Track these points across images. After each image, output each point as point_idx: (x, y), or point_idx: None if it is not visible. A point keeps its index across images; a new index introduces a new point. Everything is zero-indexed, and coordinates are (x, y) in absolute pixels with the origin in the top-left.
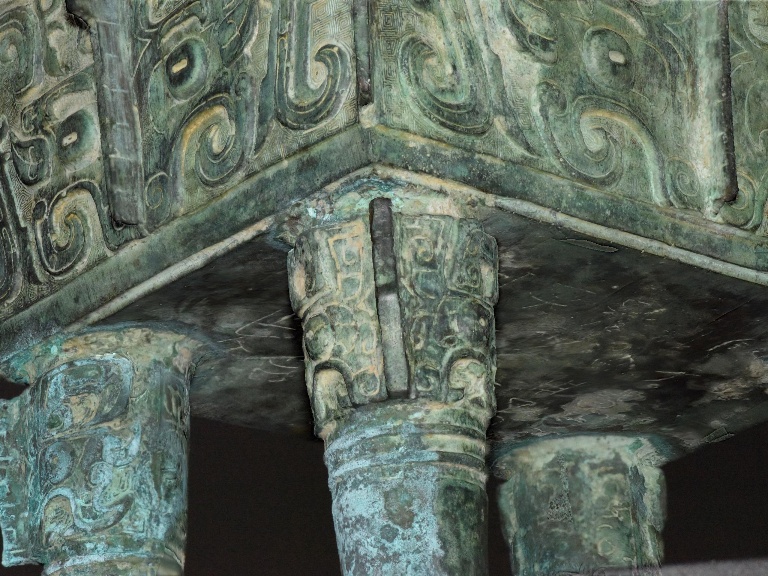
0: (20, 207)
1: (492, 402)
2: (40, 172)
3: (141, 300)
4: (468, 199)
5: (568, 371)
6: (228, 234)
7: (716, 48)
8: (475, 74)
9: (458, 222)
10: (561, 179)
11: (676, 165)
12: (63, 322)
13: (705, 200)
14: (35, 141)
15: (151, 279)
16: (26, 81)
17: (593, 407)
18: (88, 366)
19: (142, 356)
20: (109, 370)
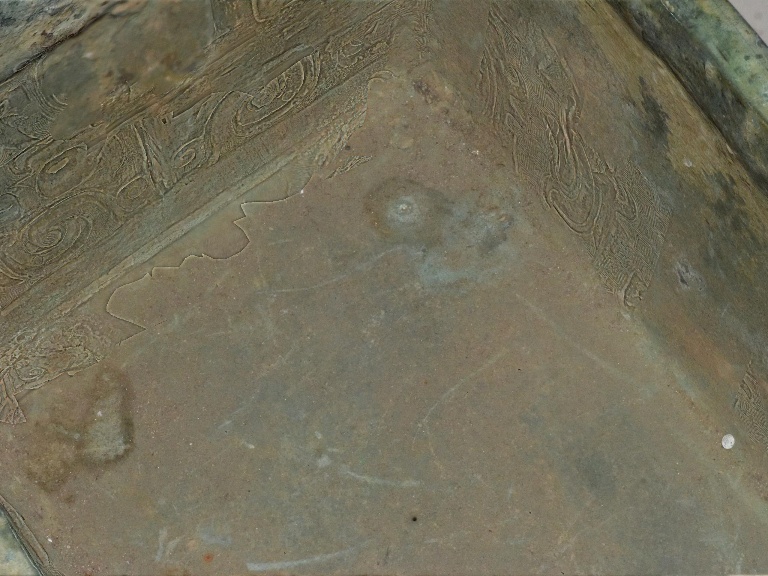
0: None
1: None
2: None
3: (230, 205)
4: None
5: None
6: (95, 277)
7: None
8: None
9: None
10: None
11: None
12: (311, 129)
13: None
14: None
15: (200, 210)
16: None
17: None
18: None
19: None
20: None
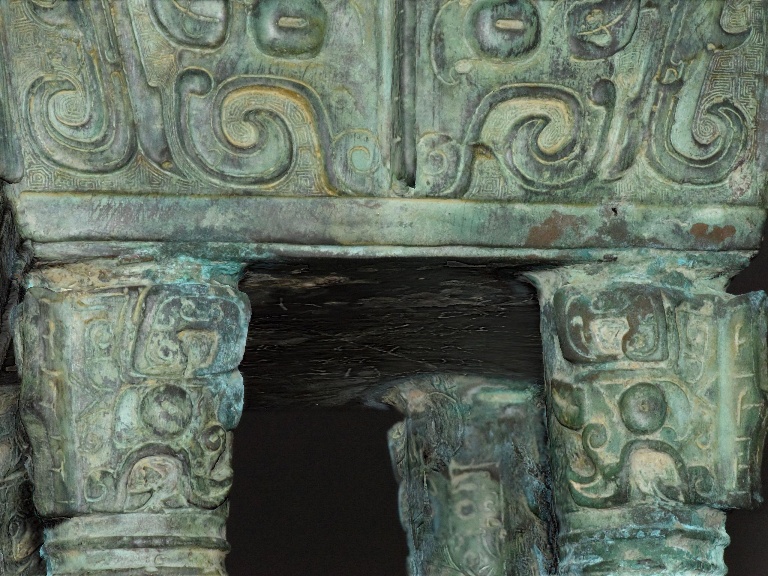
0: None
1: (21, 568)
2: None
3: None
4: None
5: (336, 320)
6: None
7: None
8: None
9: None
10: None
11: None
12: None
13: None
14: None
15: None
16: None
17: (432, 300)
18: None
19: None
20: None
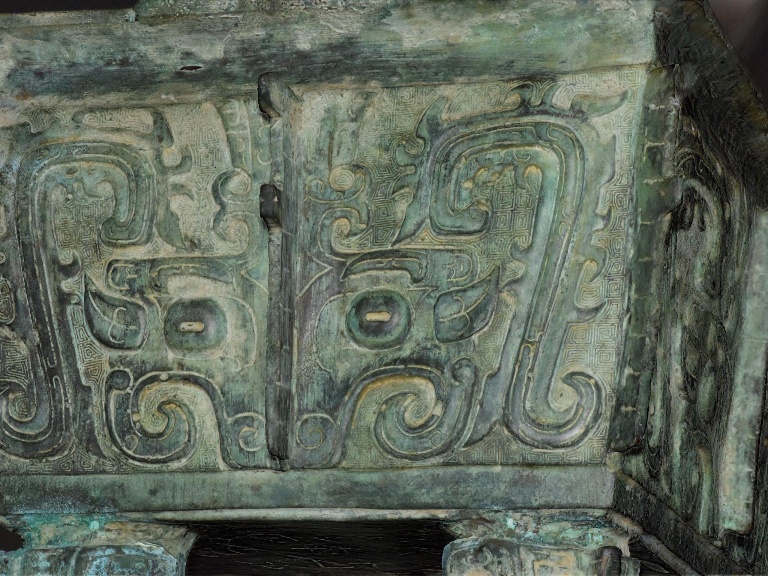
0: (82, 361)
1: None
2: (130, 340)
3: (241, 521)
4: (632, 536)
5: None
6: (396, 506)
7: (756, 384)
8: (664, 415)
9: (634, 564)
10: (674, 514)
11: (715, 495)
12: (124, 506)
13: (720, 527)
14: (130, 304)
15: (268, 509)
16: (130, 235)
17: None
18: (136, 557)
19: (172, 548)
20: (156, 566)
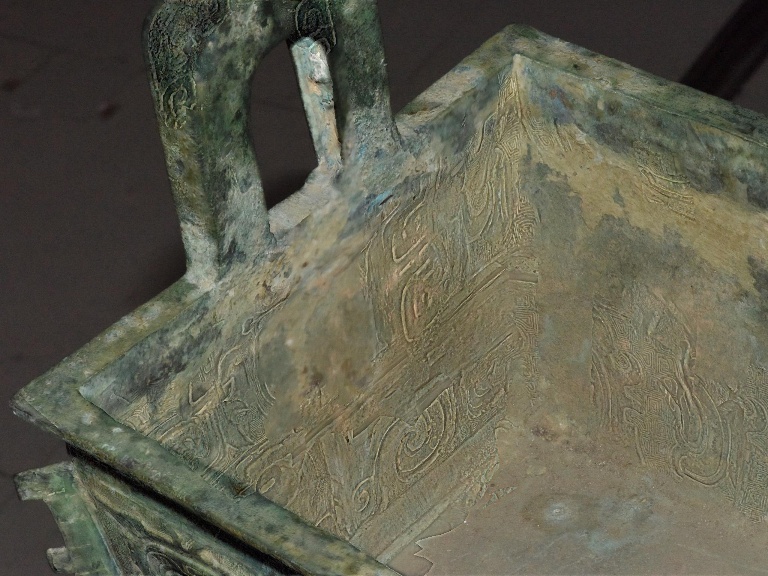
0: None
1: None
2: None
3: (405, 550)
4: None
5: None
6: None
7: None
8: None
9: None
10: None
11: None
12: (456, 481)
13: None
14: None
15: (381, 555)
16: None
17: None
18: None
19: None
20: None
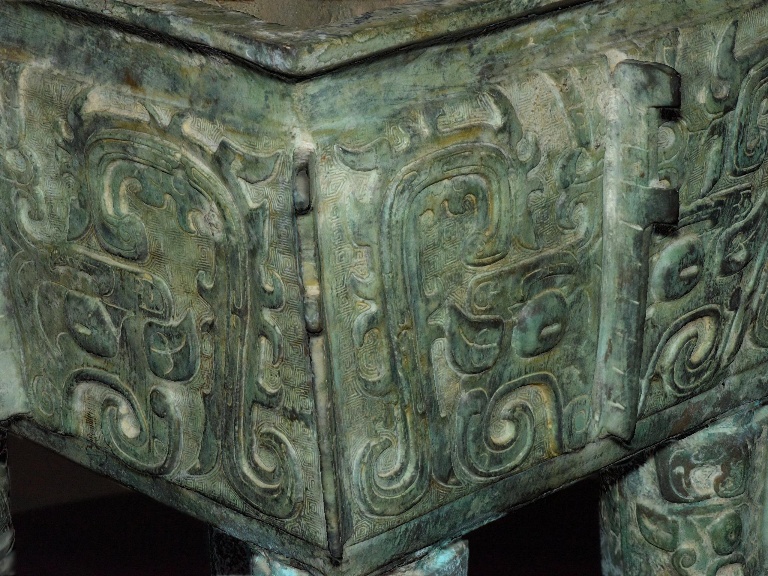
0: None
1: None
2: None
3: None
4: None
5: None
6: None
7: None
8: None
9: None
10: None
11: None
12: None
13: None
14: None
15: None
16: None
17: None
18: None
19: None
20: None
